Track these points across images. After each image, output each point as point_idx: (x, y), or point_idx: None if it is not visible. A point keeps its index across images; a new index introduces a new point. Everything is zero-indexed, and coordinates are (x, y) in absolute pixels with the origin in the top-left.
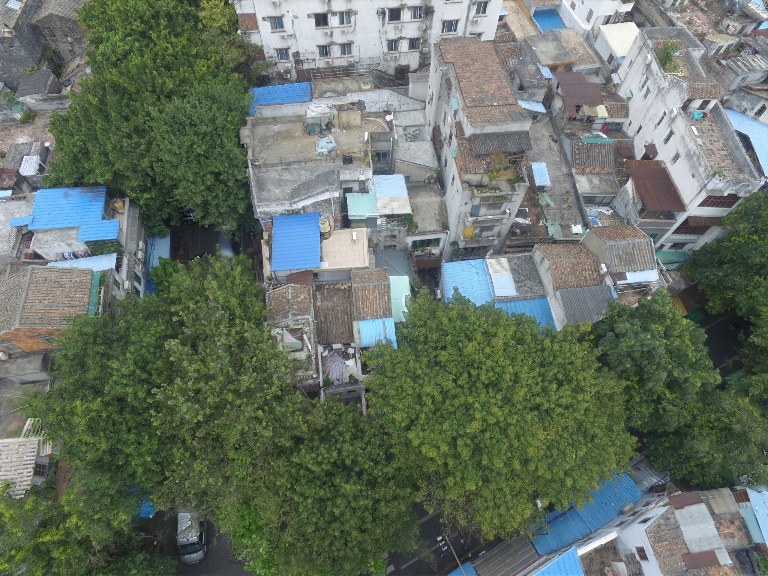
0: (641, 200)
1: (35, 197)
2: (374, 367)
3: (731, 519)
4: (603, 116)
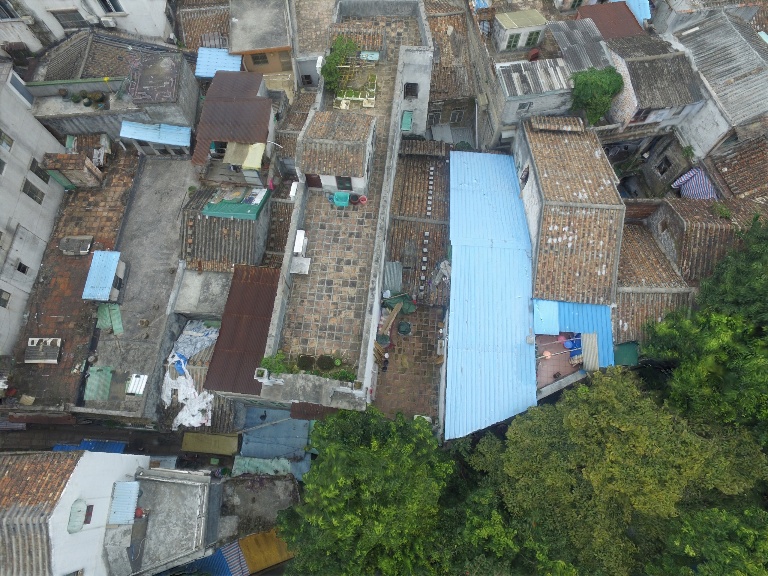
0: (211, 360)
1: None
2: None
3: None
4: (250, 166)
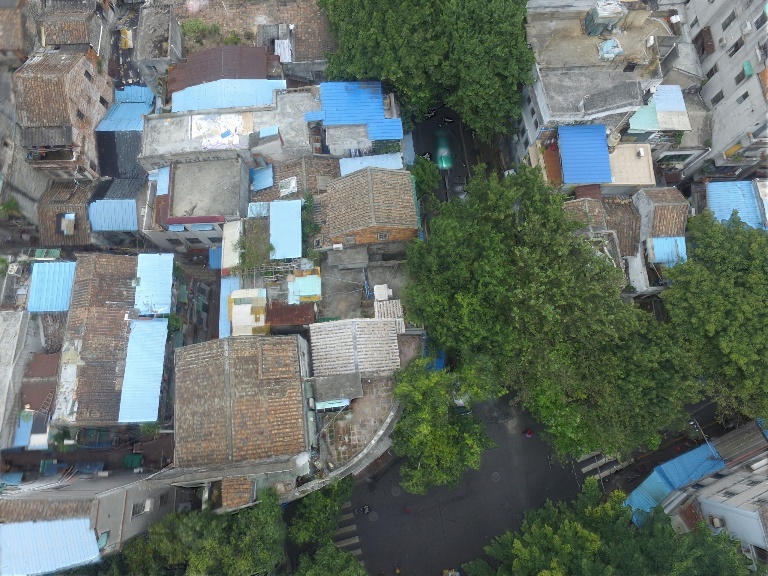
0: None
1: (320, 91)
2: (667, 281)
3: None
4: None
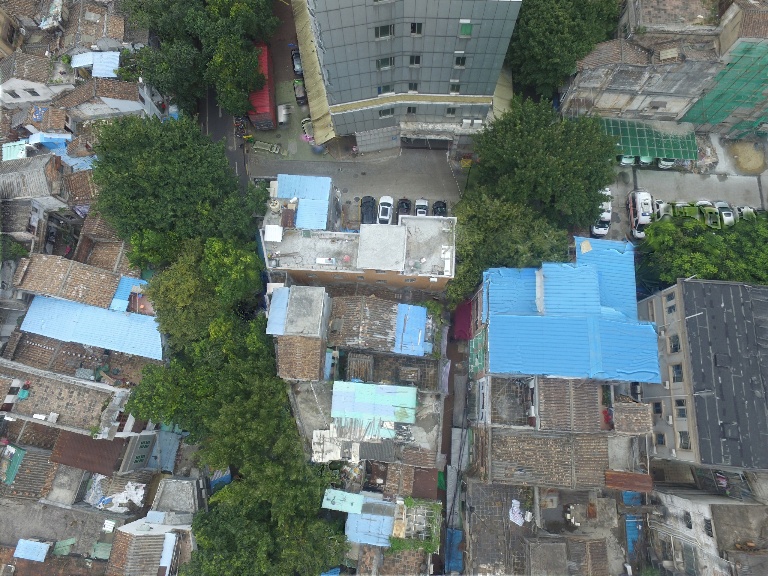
0: None
1: None
2: None
3: (363, 552)
4: None
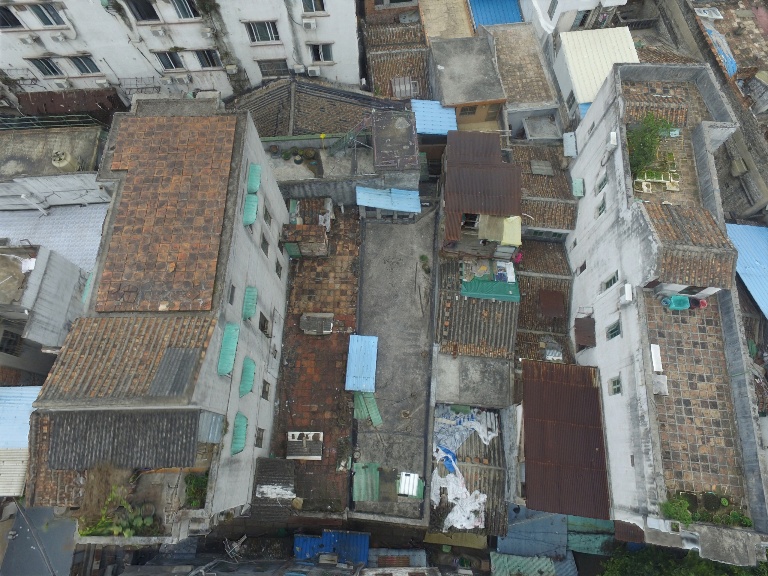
0: None
1: None
2: None
3: None
4: (510, 243)
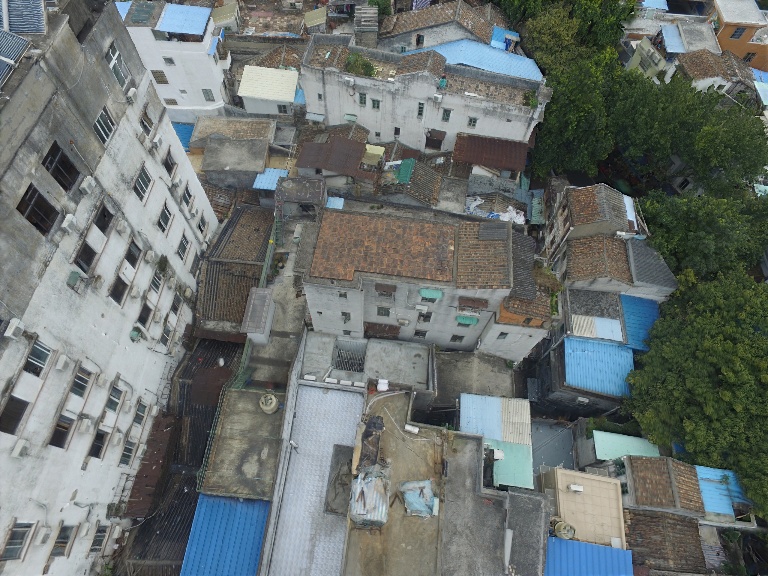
0: (508, 170)
1: None
2: None
3: None
4: (383, 152)
